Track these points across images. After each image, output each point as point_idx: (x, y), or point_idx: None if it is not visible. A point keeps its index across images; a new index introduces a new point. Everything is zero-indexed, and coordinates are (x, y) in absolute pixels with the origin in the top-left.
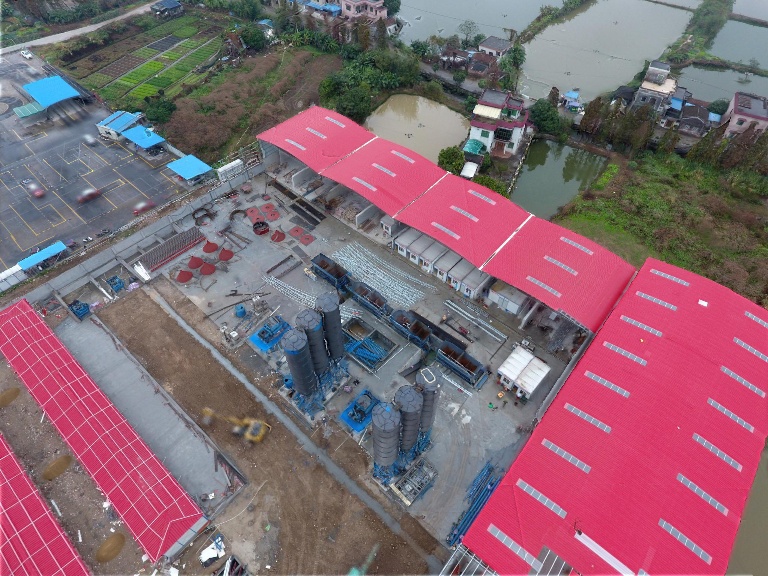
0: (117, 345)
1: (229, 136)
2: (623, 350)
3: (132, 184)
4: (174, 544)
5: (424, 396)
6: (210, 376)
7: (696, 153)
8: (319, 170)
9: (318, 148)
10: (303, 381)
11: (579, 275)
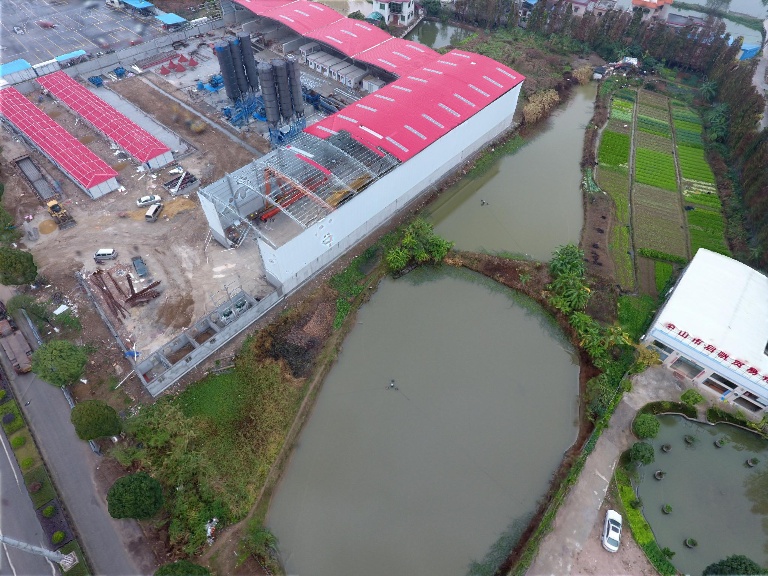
0: (121, 98)
1: (201, 7)
2: (417, 78)
3: (130, 30)
4: (154, 159)
5: (288, 67)
6: (179, 112)
7: (530, 24)
8: (258, 12)
9: (259, 1)
10: (229, 82)
11: (411, 60)
